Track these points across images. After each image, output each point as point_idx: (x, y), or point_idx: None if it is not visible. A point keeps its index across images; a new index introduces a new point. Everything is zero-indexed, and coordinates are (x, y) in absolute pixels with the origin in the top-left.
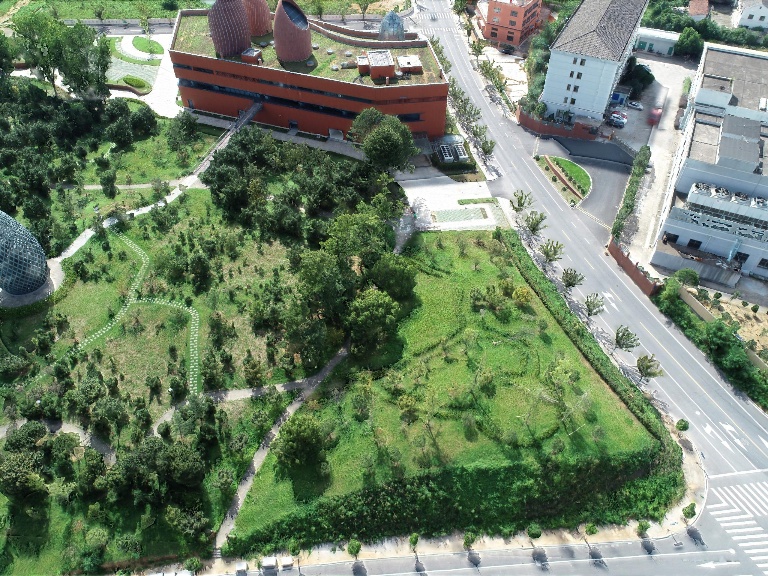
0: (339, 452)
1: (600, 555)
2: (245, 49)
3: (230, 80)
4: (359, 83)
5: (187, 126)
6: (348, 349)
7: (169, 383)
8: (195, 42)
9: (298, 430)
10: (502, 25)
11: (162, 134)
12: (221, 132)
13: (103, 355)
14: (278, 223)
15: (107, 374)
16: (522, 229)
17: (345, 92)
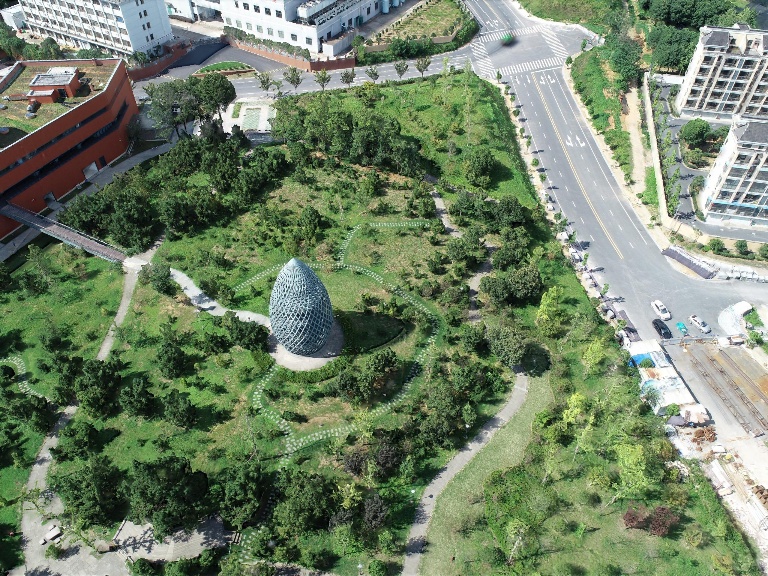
0: None
1: (519, 105)
2: None
3: None
4: (77, 104)
5: (6, 272)
6: None
7: (437, 227)
8: None
9: None
10: None
11: None
12: (14, 261)
13: None
14: (253, 186)
15: (423, 269)
16: (278, 97)
17: (82, 117)
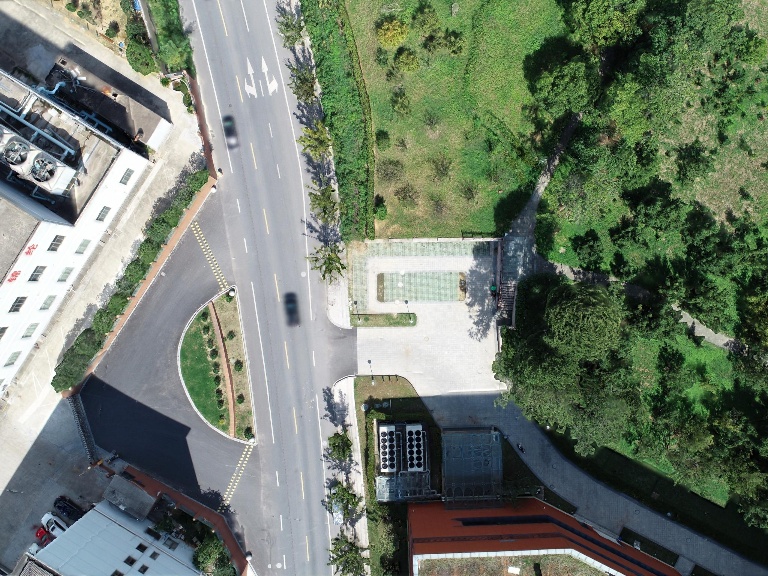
0: None
1: None
2: None
3: None
4: None
5: None
6: None
7: None
8: None
9: None
10: None
11: None
12: None
13: None
14: None
15: None
16: None
17: (626, 571)
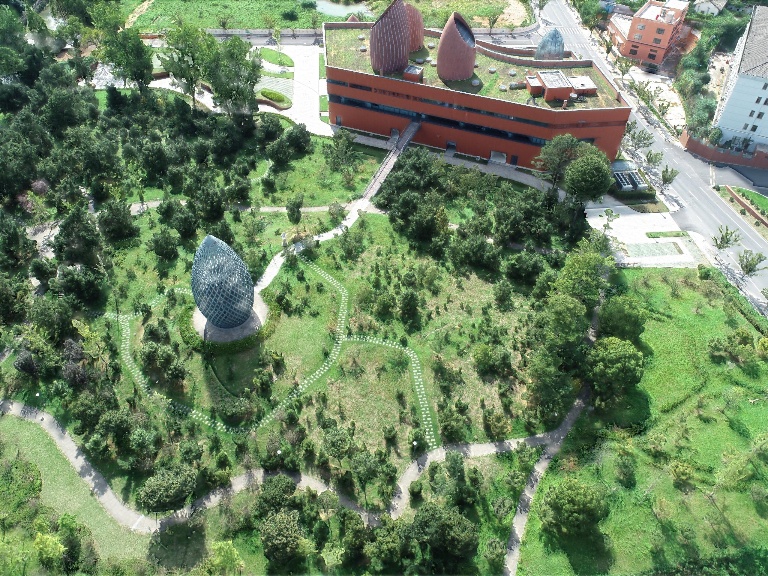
0: (614, 523)
1: None
2: (404, 66)
3: (389, 98)
4: (534, 105)
5: None
6: (584, 401)
7: (410, 435)
8: (348, 57)
9: (584, 501)
10: (645, 43)
11: (317, 152)
12: (375, 151)
13: (328, 399)
14: (473, 255)
15: (336, 421)
16: (724, 267)
17: (519, 114)
